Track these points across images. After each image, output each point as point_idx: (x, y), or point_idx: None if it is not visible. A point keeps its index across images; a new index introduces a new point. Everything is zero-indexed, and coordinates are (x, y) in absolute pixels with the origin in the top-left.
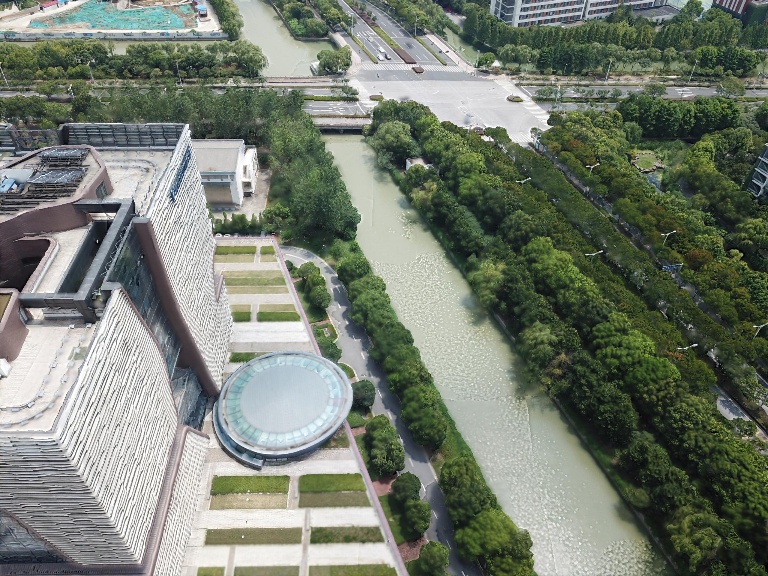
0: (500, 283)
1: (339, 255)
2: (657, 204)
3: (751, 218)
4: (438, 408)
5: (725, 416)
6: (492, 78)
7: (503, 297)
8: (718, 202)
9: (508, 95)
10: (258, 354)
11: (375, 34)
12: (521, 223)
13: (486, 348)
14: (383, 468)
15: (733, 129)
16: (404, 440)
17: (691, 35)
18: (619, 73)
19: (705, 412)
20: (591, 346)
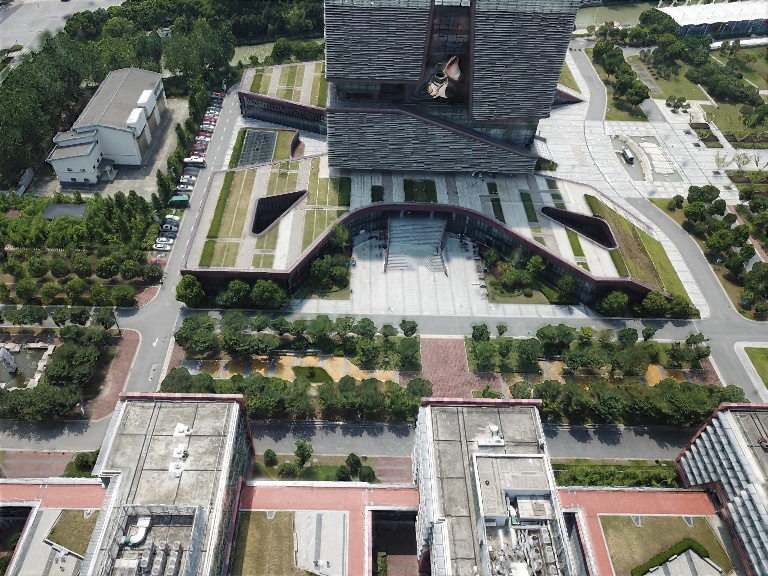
0: (305, 13)
1: (258, 62)
2: None
3: None
4: None
5: None
6: (18, 3)
7: (310, 19)
8: None
9: (57, 0)
10: None
11: None
12: None
13: None
14: None
15: None
16: None
17: None
18: None
19: None
20: None
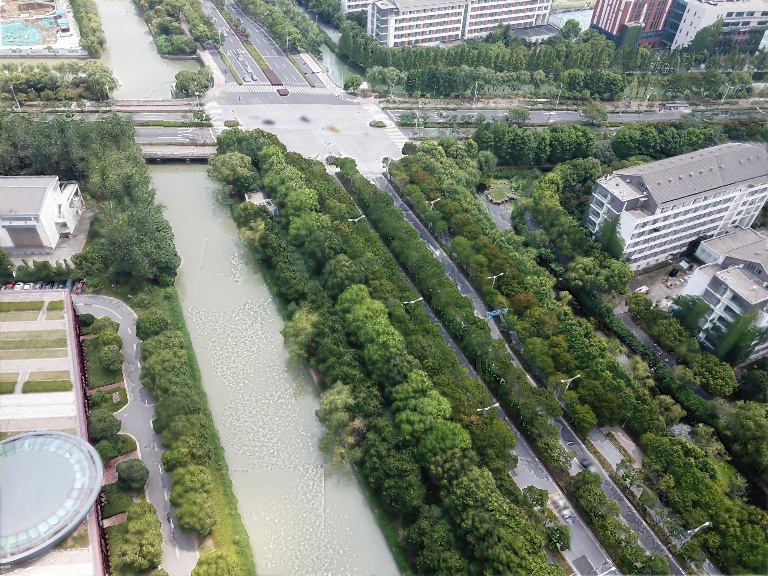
0: (308, 337)
1: (144, 307)
2: (493, 242)
3: (586, 256)
4: (221, 484)
5: (528, 479)
6: (359, 101)
7: (312, 352)
8: (556, 239)
9: (371, 120)
10: (12, 434)
11: (246, 52)
12: (338, 270)
13: (294, 408)
14: (135, 565)
15: (581, 159)
16: (175, 525)
17: (563, 57)
18: (488, 96)
19: (485, 487)
20: (392, 408)
